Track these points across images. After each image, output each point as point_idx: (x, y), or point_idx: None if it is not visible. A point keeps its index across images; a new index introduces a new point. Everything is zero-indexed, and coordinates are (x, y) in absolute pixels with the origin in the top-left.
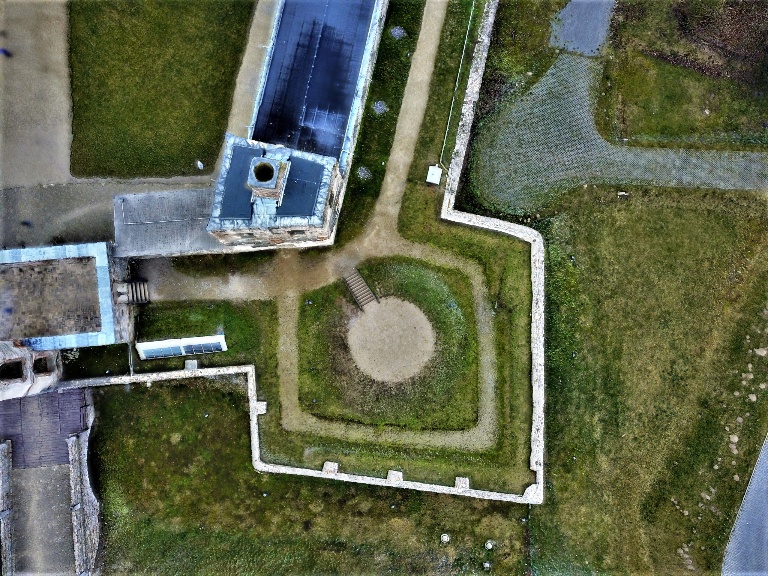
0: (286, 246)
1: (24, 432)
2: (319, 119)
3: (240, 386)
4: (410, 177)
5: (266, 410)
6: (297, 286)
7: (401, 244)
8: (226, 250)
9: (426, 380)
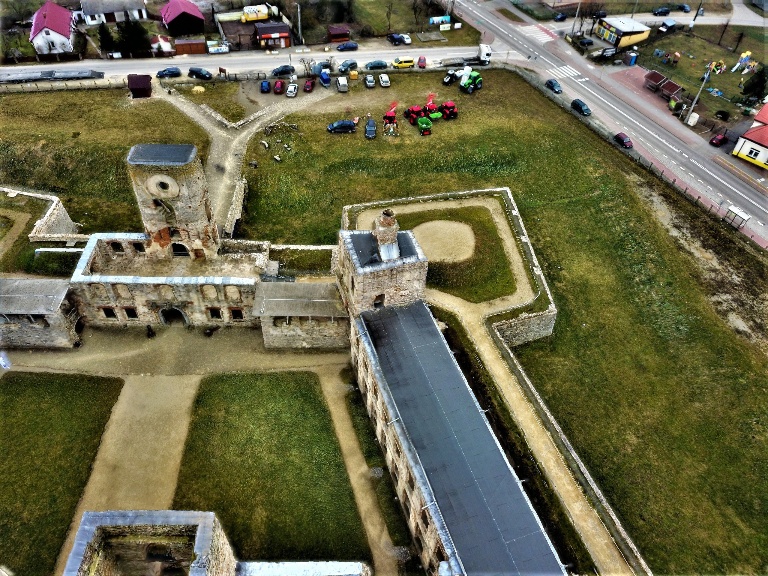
0: None
1: None
2: None
3: None
4: None
5: None
6: None
7: None
8: None
9: None
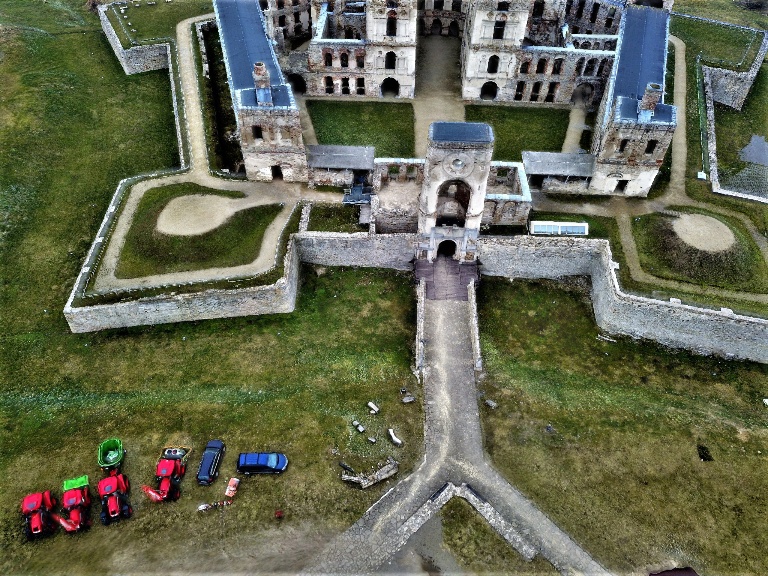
0: (617, 194)
1: (435, 280)
2: None
3: (579, 286)
4: (687, 176)
5: (619, 268)
6: (627, 213)
7: (691, 201)
8: (581, 190)
9: (734, 256)
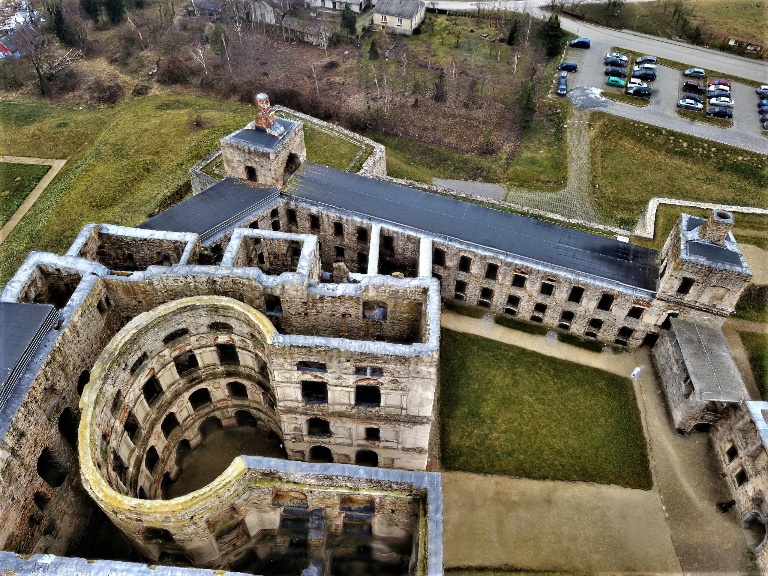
0: None
1: None
2: (625, 254)
3: None
4: None
5: None
6: None
7: None
8: None
9: None
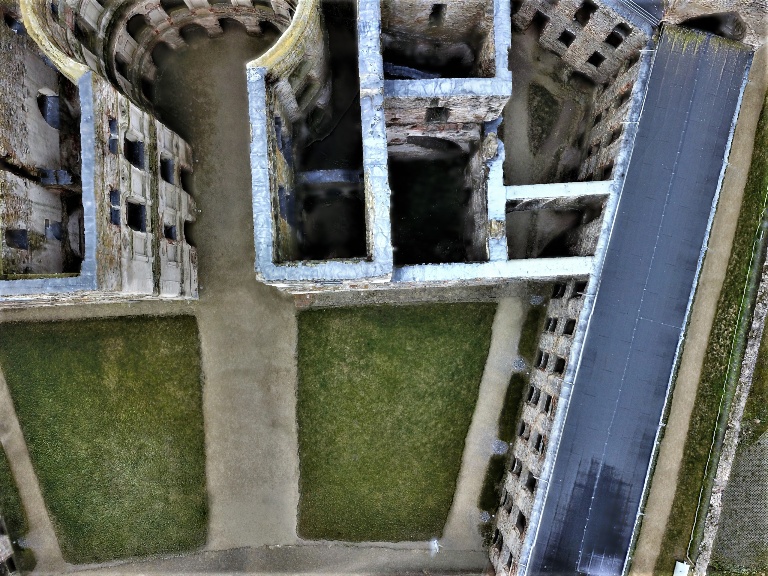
0: None
1: None
2: (595, 564)
3: None
4: (656, 572)
5: None
6: None
7: None
8: None
9: None
